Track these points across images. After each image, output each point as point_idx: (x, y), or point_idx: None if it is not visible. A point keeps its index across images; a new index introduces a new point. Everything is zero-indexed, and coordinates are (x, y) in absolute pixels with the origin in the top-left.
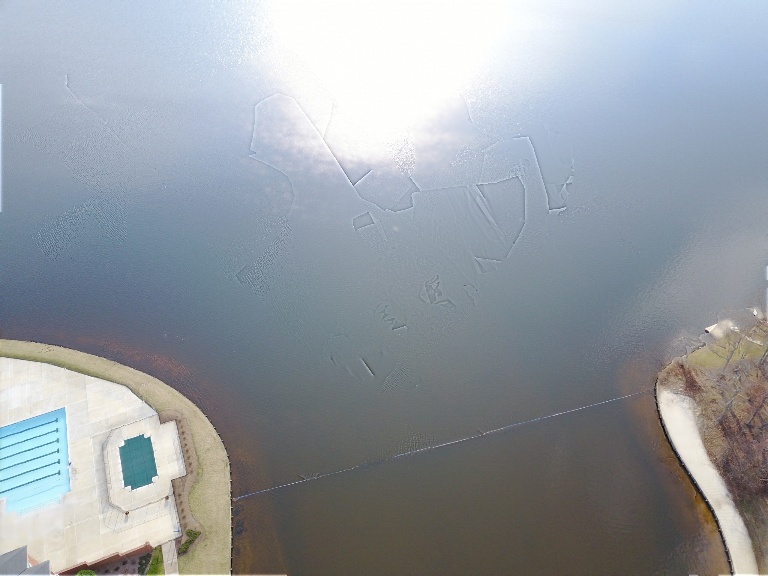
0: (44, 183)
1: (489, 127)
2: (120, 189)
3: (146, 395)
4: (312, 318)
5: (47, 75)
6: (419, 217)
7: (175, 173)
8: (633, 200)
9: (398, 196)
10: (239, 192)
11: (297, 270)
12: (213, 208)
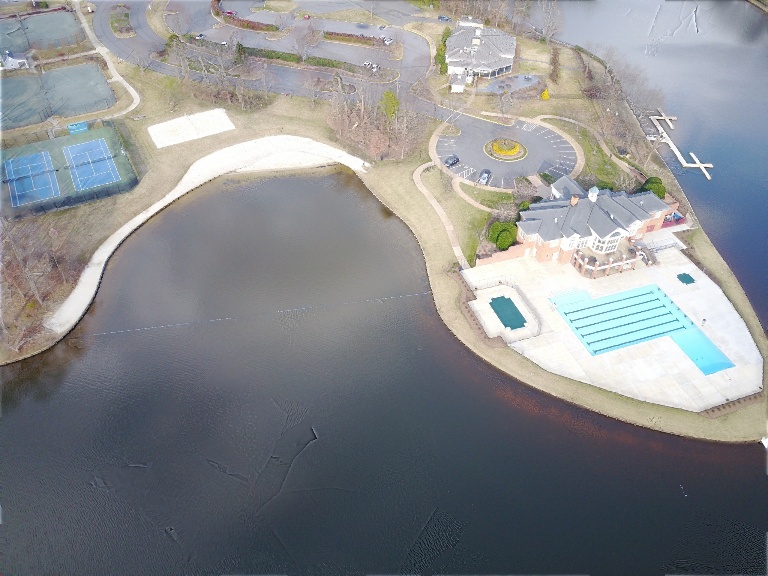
0: None
1: None
2: None
3: (525, 362)
4: None
5: None
6: (196, 517)
7: None
8: None
9: None
10: None
11: None
12: (527, 574)
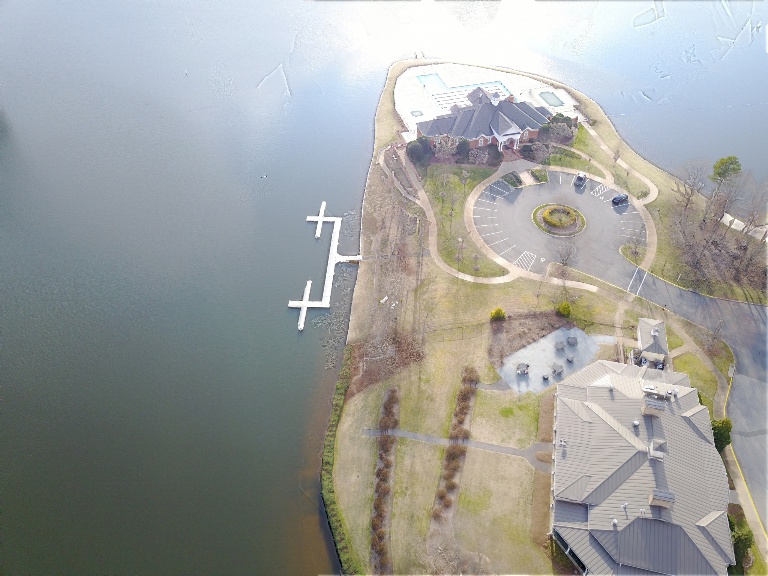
0: None
1: None
2: None
3: None
4: (608, 71)
5: None
6: None
7: None
8: None
9: (661, 8)
10: None
11: (601, 43)
12: (551, 4)
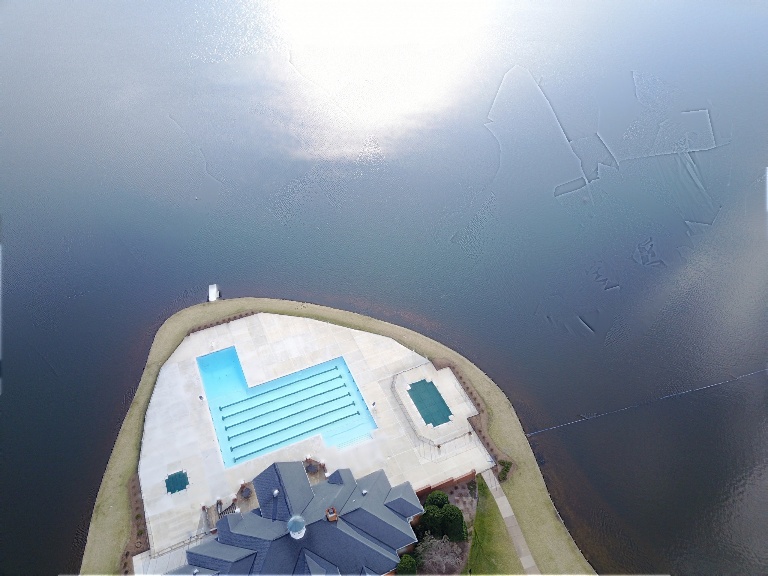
0: (275, 153)
1: (654, 102)
2: (345, 158)
3: (413, 345)
4: (525, 280)
5: (272, 51)
6: None
7: (394, 143)
8: None
9: (594, 165)
10: (449, 162)
11: (509, 235)
12: (427, 177)
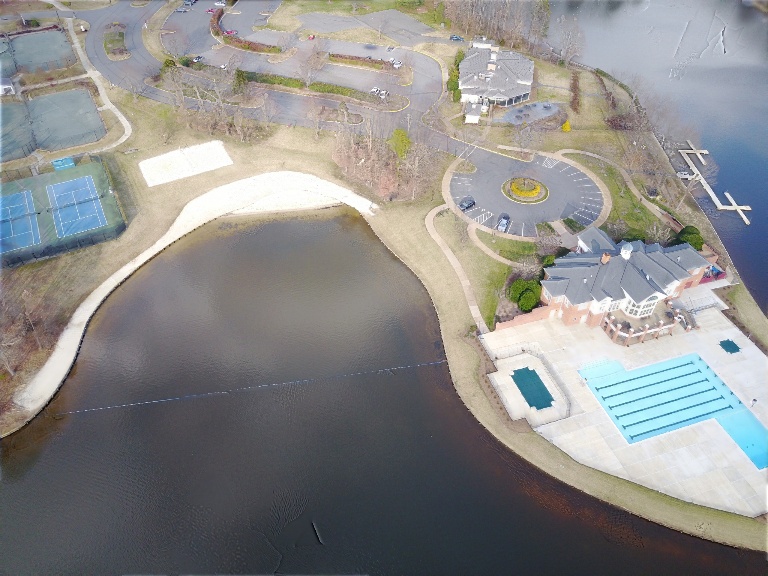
0: None
1: None
2: None
3: (553, 451)
4: None
5: None
6: None
7: None
8: None
9: None
10: None
11: None
12: None
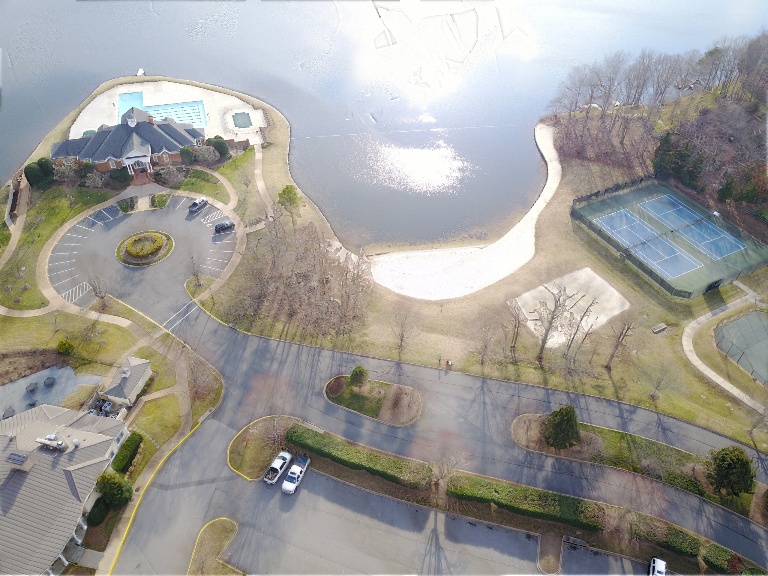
0: None
1: (474, 5)
2: (237, 5)
3: None
4: (343, 92)
5: None
6: None
7: None
8: (560, 51)
9: None
10: (306, 16)
11: (337, 63)
12: (290, 23)
